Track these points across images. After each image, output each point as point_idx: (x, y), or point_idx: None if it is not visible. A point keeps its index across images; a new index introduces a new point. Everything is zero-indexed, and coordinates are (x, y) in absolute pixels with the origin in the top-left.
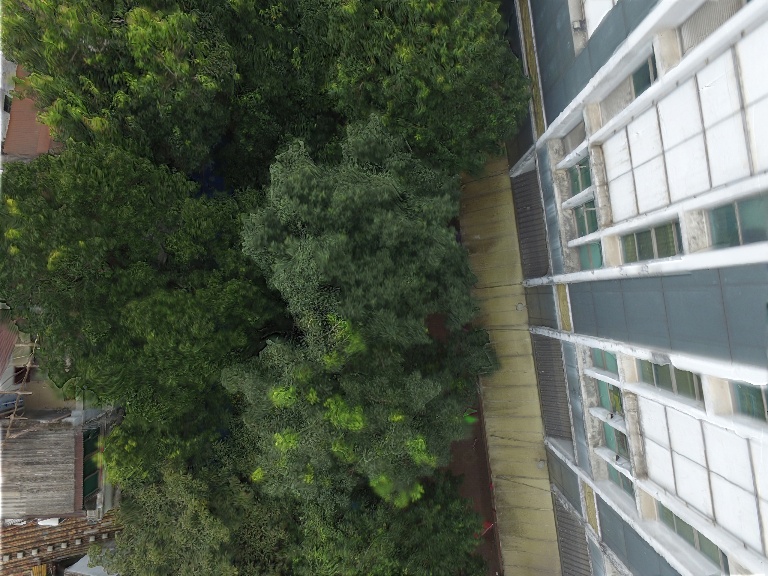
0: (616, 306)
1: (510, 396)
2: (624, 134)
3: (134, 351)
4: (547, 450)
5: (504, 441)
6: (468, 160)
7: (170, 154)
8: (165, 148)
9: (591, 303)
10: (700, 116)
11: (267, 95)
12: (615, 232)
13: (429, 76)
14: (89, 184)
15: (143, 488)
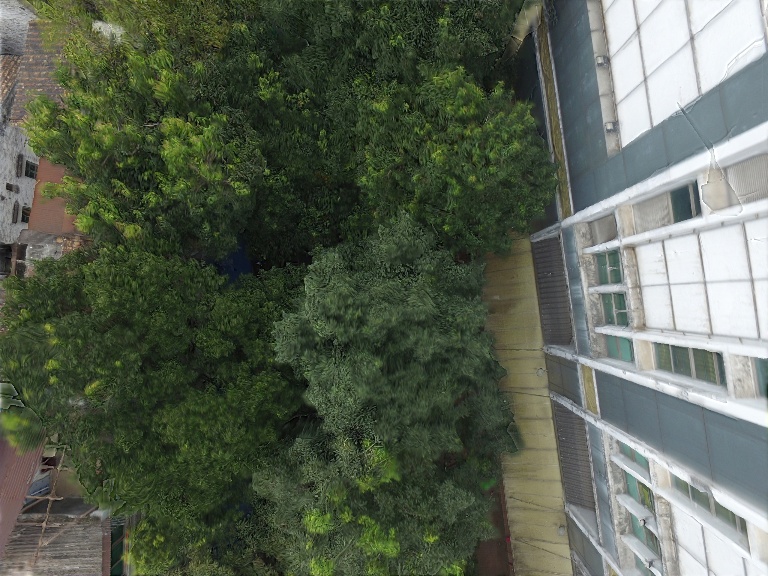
0: (649, 413)
1: (529, 459)
2: (660, 247)
3: (166, 458)
4: (567, 516)
5: (523, 503)
6: (494, 243)
7: (198, 244)
8: (193, 238)
9: (621, 398)
10: (748, 265)
11: (292, 175)
12: (649, 340)
13: (460, 174)
14: (124, 298)
15: (168, 572)
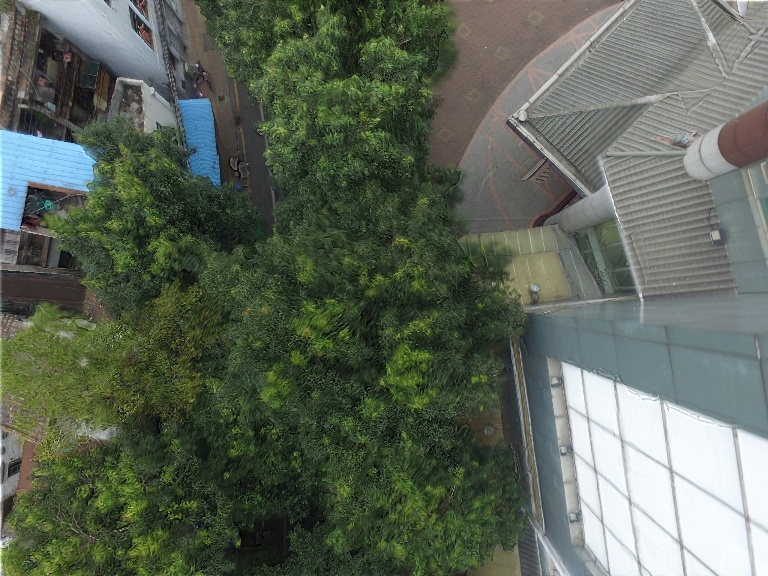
0: None
1: None
2: None
3: None
4: None
5: None
6: None
7: None
8: None
9: None
10: None
11: (268, 484)
12: None
13: (427, 550)
14: None
15: None
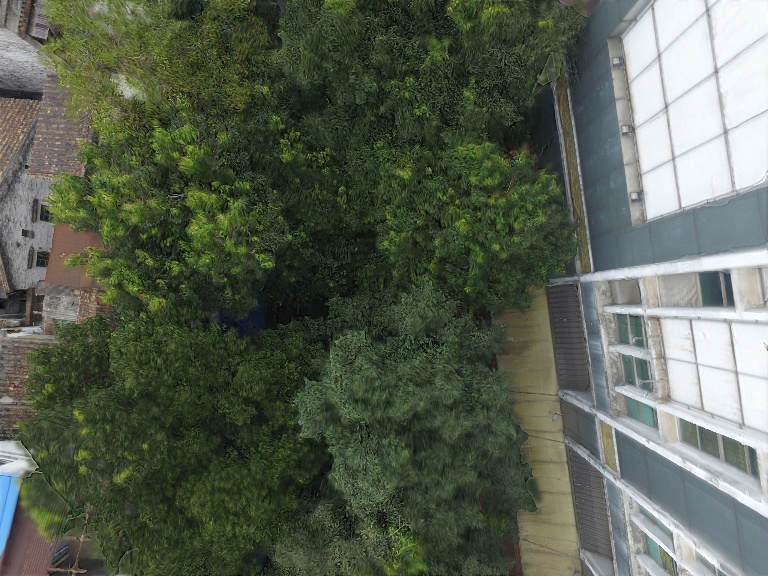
0: (675, 487)
1: (543, 502)
2: (688, 325)
3: (190, 532)
4: (582, 561)
5: (537, 546)
6: (514, 301)
7: (219, 306)
8: (214, 300)
9: (643, 464)
10: None
11: (311, 229)
12: (675, 415)
13: (483, 241)
14: (150, 377)
15: None
